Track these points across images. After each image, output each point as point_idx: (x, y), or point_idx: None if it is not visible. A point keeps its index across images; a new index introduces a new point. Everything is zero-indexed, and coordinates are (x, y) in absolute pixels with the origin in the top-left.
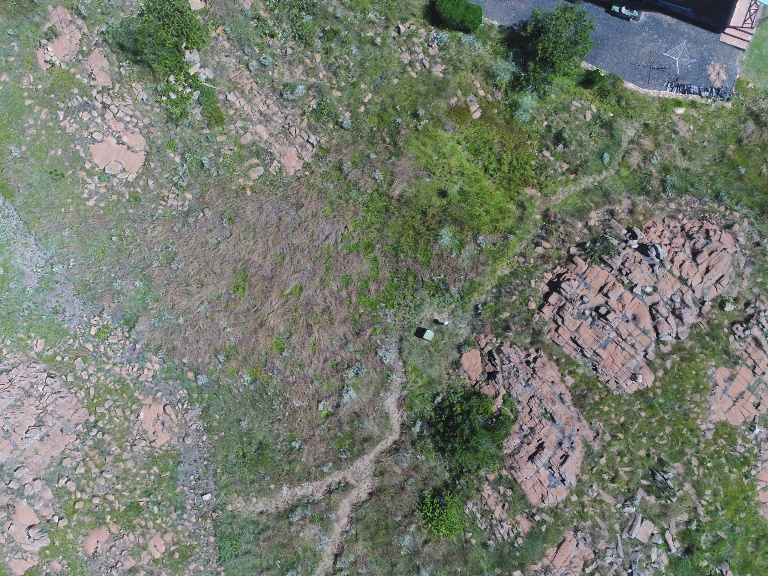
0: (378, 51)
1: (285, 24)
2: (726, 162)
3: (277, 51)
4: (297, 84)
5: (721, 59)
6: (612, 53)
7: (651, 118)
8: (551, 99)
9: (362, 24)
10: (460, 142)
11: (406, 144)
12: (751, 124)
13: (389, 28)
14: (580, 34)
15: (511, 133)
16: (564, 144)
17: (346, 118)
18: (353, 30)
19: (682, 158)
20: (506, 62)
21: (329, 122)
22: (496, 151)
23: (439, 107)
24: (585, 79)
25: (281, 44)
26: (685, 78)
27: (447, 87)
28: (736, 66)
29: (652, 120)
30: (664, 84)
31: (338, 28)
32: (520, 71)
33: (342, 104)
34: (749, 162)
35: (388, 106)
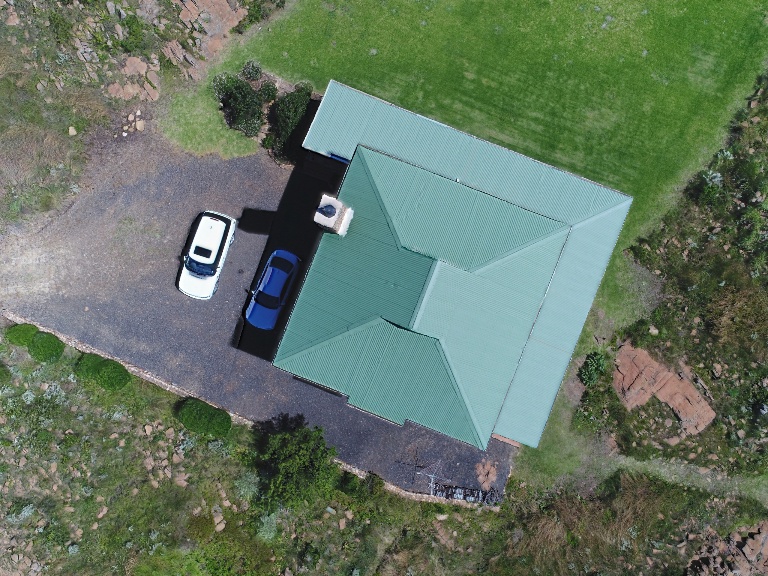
0: (120, 457)
1: (23, 427)
2: (489, 572)
3: (10, 461)
4: (25, 503)
5: (493, 456)
6: (376, 449)
7: (411, 524)
8: (304, 505)
9: (107, 424)
10: (199, 560)
11: (136, 570)
12: (520, 530)
13: (136, 427)
14: (317, 468)
15: (254, 549)
16: (307, 567)
17: (77, 536)
18: (96, 431)
19: (442, 568)
20: (249, 479)
21: (55, 547)
22: (235, 571)
23: (177, 524)
24: (340, 486)
25: (16, 452)
26: (452, 478)
27: (188, 500)
28: (509, 463)
29: (412, 526)
30: (429, 485)
31: (81, 429)
32: (261, 493)
33: (74, 521)
34: (512, 575)
35: (123, 523)
